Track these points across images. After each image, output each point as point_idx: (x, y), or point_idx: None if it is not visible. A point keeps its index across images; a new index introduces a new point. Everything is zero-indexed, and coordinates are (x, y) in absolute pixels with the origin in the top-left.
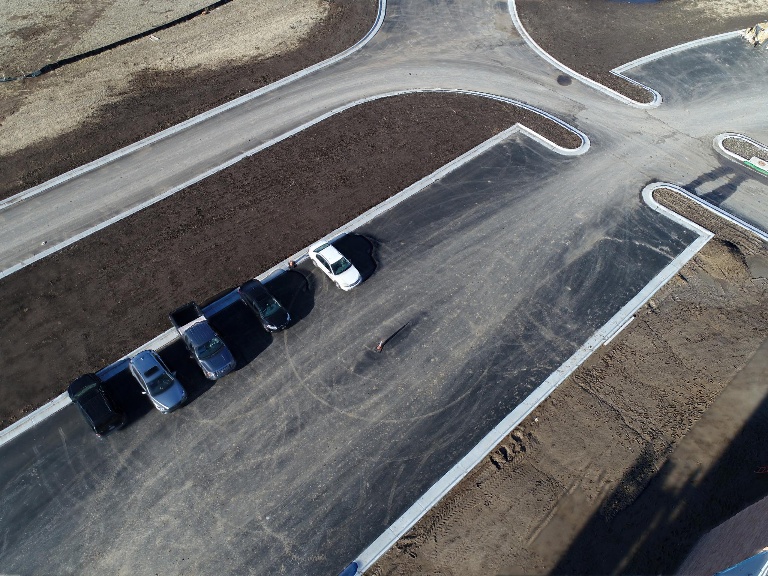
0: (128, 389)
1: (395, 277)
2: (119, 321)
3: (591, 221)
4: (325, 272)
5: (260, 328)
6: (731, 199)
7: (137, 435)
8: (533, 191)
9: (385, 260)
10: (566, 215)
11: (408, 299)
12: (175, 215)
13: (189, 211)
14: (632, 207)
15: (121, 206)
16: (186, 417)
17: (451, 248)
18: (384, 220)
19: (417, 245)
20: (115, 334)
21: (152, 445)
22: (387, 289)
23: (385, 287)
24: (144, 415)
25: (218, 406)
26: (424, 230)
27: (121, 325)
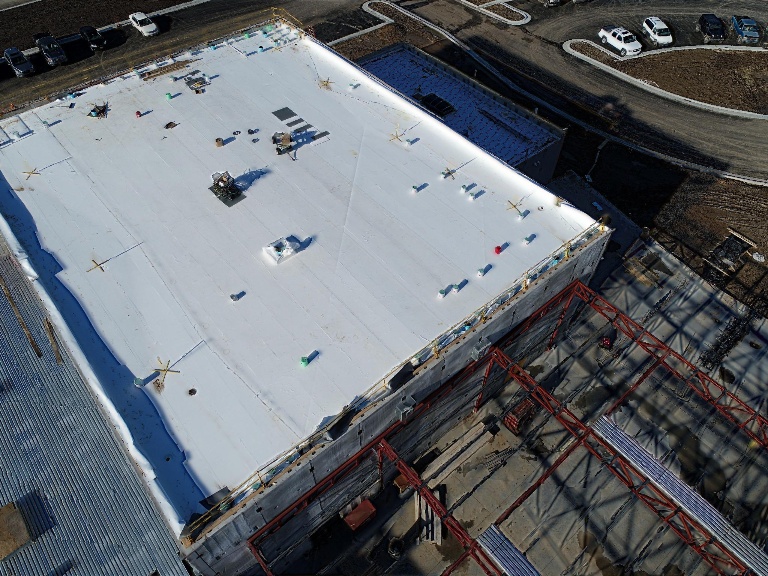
0: (3, 69)
1: (181, 33)
2: (5, 44)
3: (321, 15)
4: (137, 28)
5: (89, 50)
6: (420, 8)
7: (3, 85)
8: (292, 1)
9: (179, 26)
10: (306, 12)
11: (184, 42)
12: (55, 4)
13: (64, 3)
14: (352, 10)
15: (22, 1)
16: (33, 80)
17: (223, 23)
18: (187, 10)
19: (202, 21)
20: (1, 48)
21: (11, 89)
22: (174, 38)
23: (173, 37)
24: (9, 79)
25: (53, 77)
26: (210, 15)
27: (6, 45)
